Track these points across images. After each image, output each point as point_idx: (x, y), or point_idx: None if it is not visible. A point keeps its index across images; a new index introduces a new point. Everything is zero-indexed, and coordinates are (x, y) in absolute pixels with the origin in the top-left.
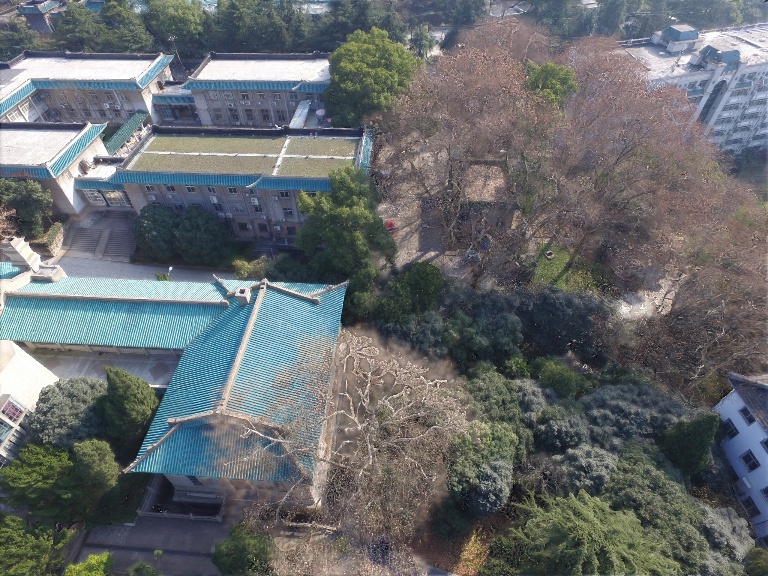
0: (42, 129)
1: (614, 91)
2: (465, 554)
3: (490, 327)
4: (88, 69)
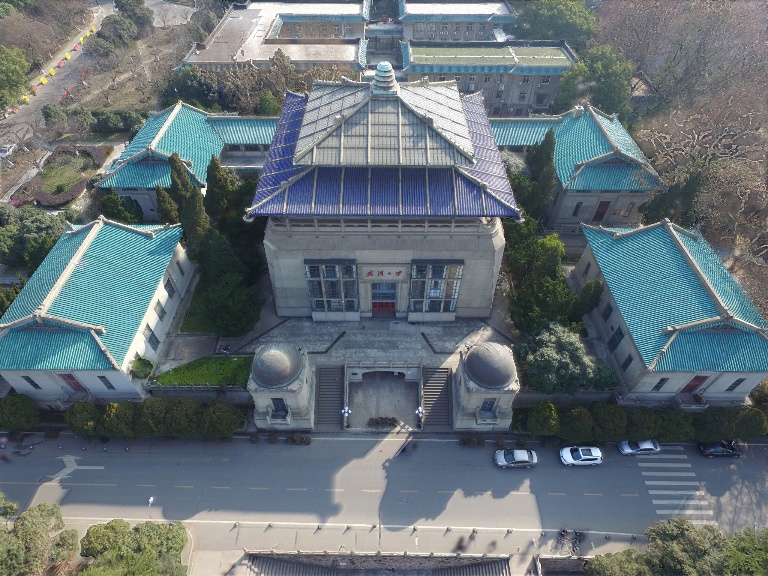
0: (322, 44)
1: (755, 3)
2: (737, 242)
3: (703, 144)
4: (313, 9)
